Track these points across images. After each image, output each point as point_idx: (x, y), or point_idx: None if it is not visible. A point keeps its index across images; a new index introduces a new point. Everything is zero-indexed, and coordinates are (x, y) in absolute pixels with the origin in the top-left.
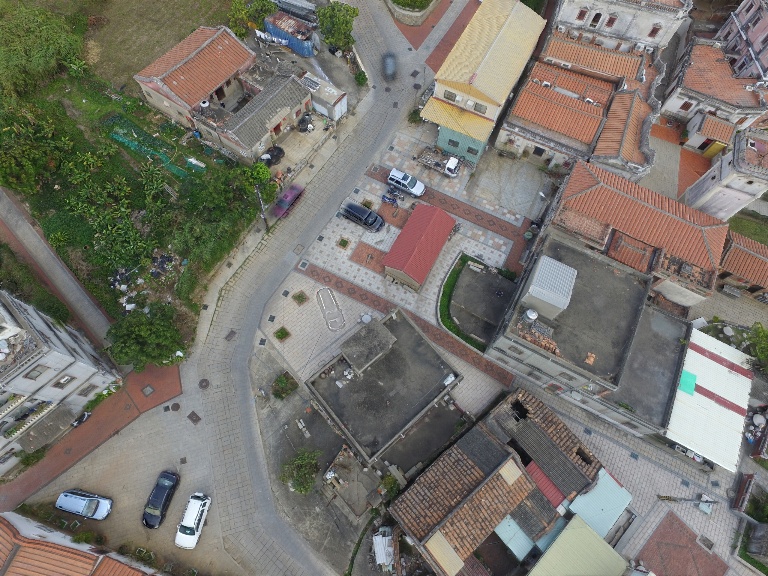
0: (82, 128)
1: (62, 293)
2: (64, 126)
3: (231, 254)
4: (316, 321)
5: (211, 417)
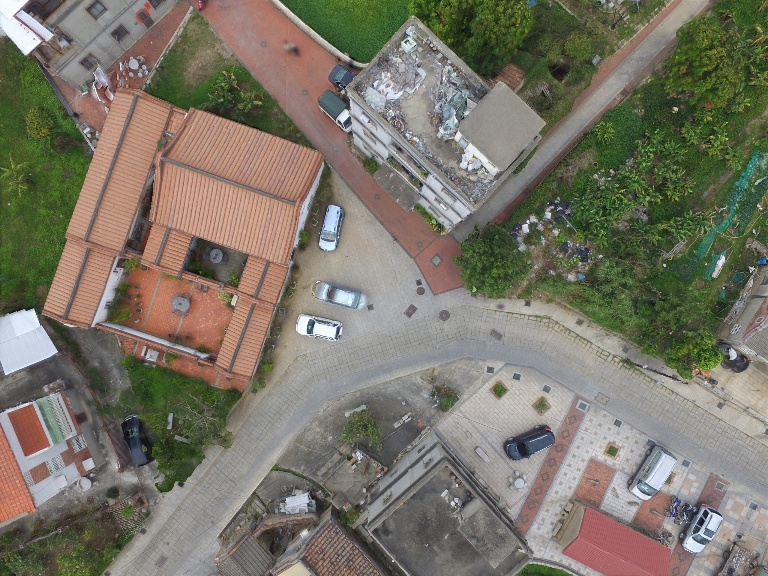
0: (766, 113)
1: (539, 148)
2: (767, 93)
3: (594, 324)
4: (516, 425)
5: (412, 327)
